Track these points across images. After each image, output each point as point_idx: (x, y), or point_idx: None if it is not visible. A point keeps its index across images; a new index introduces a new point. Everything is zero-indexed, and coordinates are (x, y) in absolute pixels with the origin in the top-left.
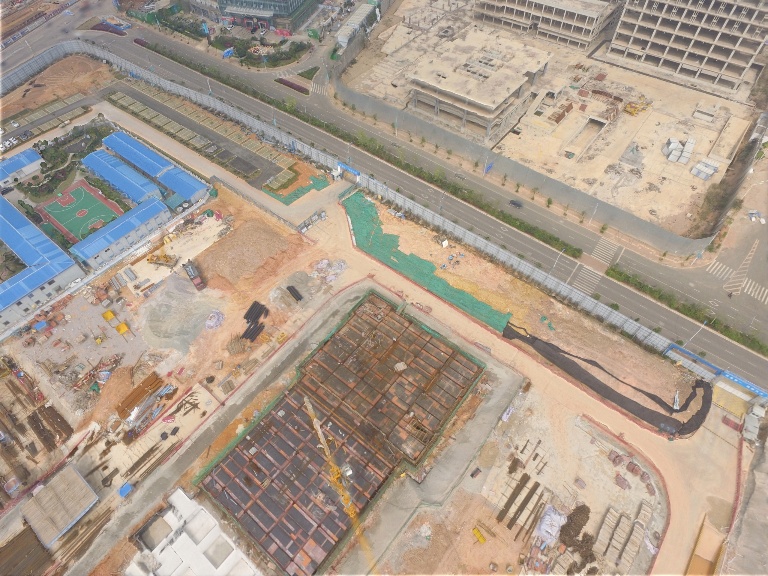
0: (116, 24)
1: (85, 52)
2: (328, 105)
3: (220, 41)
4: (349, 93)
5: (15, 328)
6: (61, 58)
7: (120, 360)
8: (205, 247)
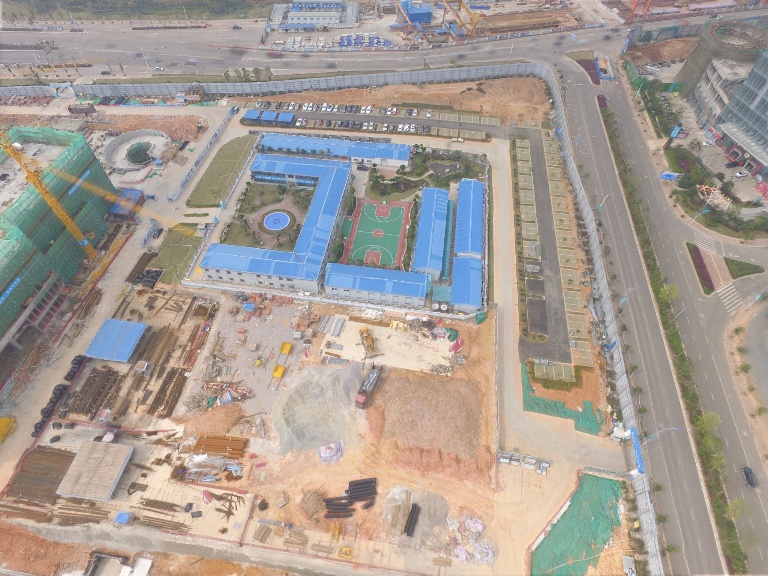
0: (602, 69)
1: (546, 81)
2: (718, 329)
3: (678, 153)
4: (761, 346)
5: (242, 289)
6: (523, 75)
7: (247, 398)
8: (410, 367)
